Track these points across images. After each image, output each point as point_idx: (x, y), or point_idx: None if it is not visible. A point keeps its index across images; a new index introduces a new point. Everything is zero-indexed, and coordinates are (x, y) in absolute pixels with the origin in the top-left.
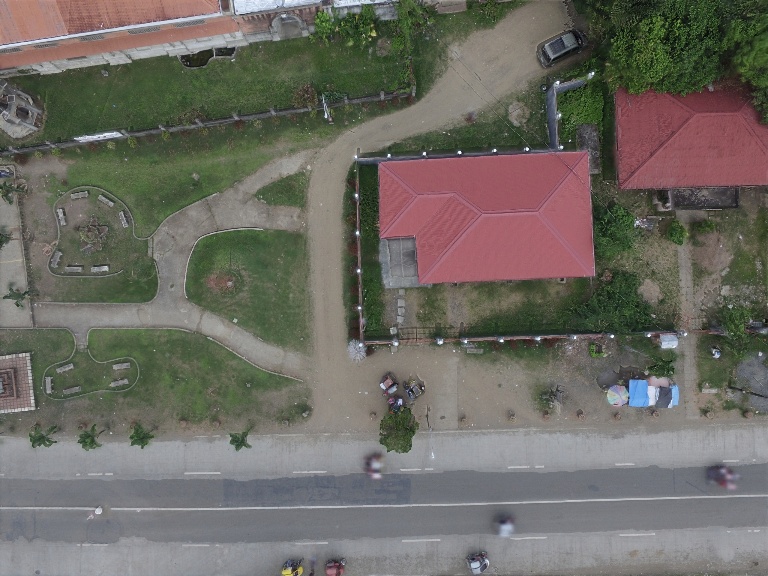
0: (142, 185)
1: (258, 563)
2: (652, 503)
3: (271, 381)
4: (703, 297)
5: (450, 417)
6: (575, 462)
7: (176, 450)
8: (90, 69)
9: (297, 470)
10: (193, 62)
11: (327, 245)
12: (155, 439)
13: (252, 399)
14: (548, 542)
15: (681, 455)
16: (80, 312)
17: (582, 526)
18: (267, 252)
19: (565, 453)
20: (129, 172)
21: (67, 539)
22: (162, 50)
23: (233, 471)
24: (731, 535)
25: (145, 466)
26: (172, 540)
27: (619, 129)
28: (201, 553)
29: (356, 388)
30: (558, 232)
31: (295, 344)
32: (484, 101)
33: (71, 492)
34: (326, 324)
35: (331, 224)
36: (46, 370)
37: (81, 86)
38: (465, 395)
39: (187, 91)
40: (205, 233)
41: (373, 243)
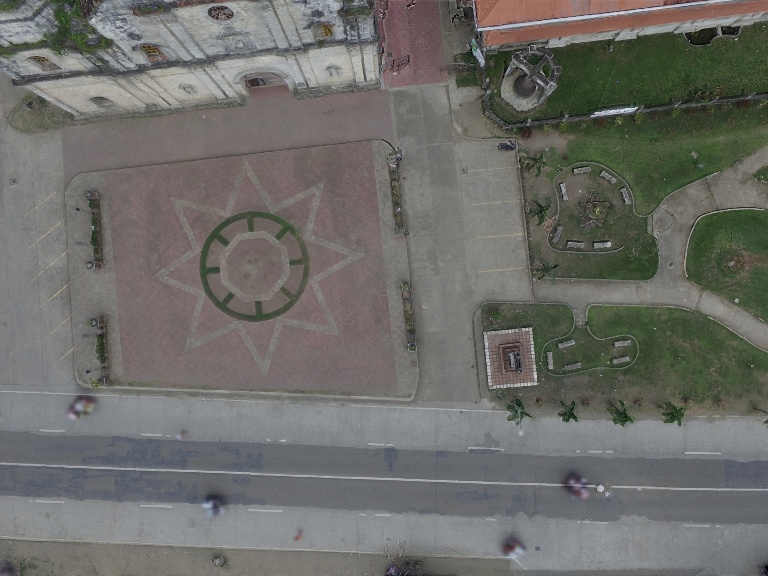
0: (642, 162)
1: (758, 545)
2: None
3: None
4: None
5: None
6: None
7: (676, 429)
8: (594, 44)
9: None
10: (694, 40)
11: None
12: (655, 418)
13: (753, 380)
14: None
15: None
16: (579, 288)
17: None
18: (767, 233)
19: None
20: (629, 148)
21: (567, 516)
22: (675, 26)
23: (733, 452)
24: None
25: (645, 444)
26: (673, 520)
27: None
28: (702, 533)
29: None
30: None
31: None
32: None
33: (571, 469)
34: None
35: None
36: (545, 345)
37: (584, 61)
38: None
39: (691, 69)
40: (705, 212)
41: None
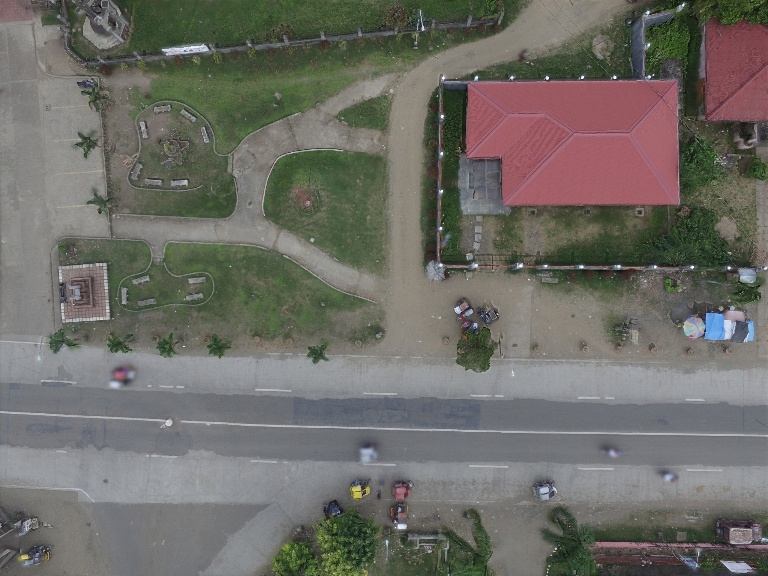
0: (224, 102)
1: (325, 482)
2: (721, 440)
3: (345, 302)
4: None
5: (522, 345)
6: (645, 395)
7: (248, 366)
8: None
9: (367, 391)
10: None
11: (407, 169)
12: (227, 354)
13: (326, 319)
14: (615, 474)
15: (751, 393)
16: (158, 225)
17: (650, 459)
18: (346, 173)
19: (636, 386)
20: (212, 88)
21: (136, 449)
22: None
23: (304, 389)
24: None
25: (216, 380)
26: (240, 455)
27: (704, 64)
28: (269, 469)
29: (430, 312)
30: (647, 156)
31: (371, 266)
32: (568, 33)
33: (142, 403)
34: (402, 247)
35: (411, 148)
36: (122, 281)
37: (168, 1)
38: (538, 324)
39: (273, 10)
40: (285, 152)
41: (453, 169)
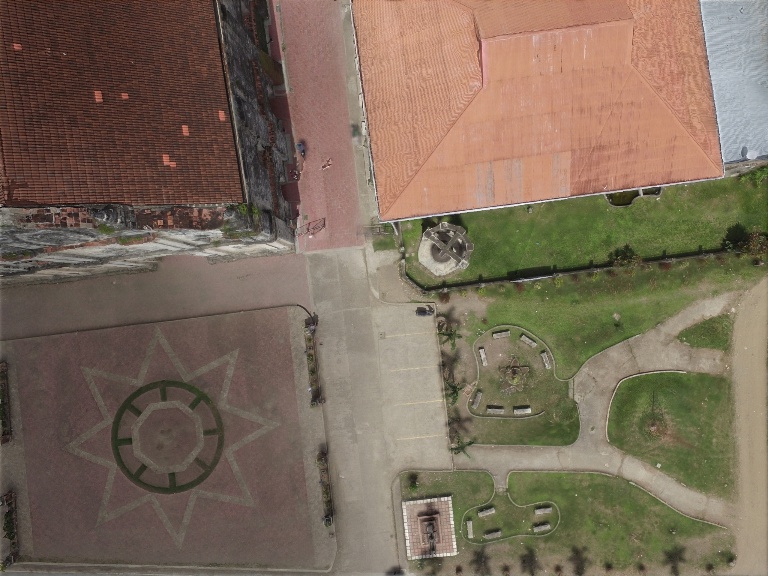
0: (563, 324)
1: None
2: None
3: (694, 528)
4: None
5: None
6: None
7: None
8: None
9: None
10: (615, 199)
11: (752, 390)
12: None
13: (675, 546)
14: None
15: None
16: (499, 454)
17: None
18: (690, 396)
19: None
20: (550, 311)
21: None
22: None
23: None
24: None
25: None
26: None
27: None
28: None
29: None
30: None
31: (718, 490)
32: None
33: None
34: (751, 471)
35: (756, 368)
36: (465, 513)
37: (504, 222)
38: None
39: (612, 230)
40: (627, 375)
41: None
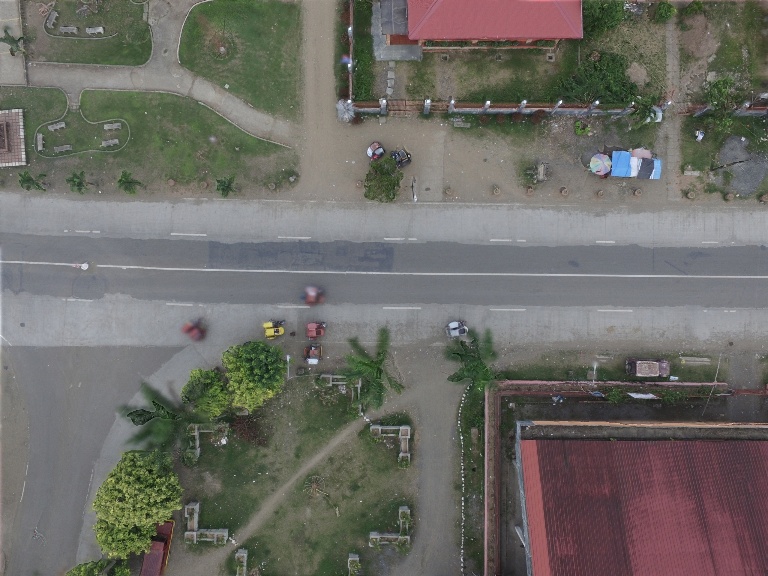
0: None
1: (240, 324)
2: (631, 281)
3: (260, 147)
4: (689, 82)
5: (435, 189)
6: (556, 238)
7: (163, 211)
8: None
9: (282, 235)
10: None
11: (320, 16)
12: (143, 199)
13: (240, 164)
14: (527, 315)
15: (661, 235)
16: (74, 73)
17: (561, 300)
18: (261, 21)
19: (547, 229)
20: None
21: (53, 293)
22: None
23: (219, 233)
24: (707, 315)
25: (132, 225)
26: (156, 298)
27: None
28: (184, 312)
29: (343, 157)
30: None
31: (285, 112)
32: None
33: (58, 248)
34: (316, 93)
35: None
36: (38, 128)
37: None
38: (451, 168)
39: None
40: (200, 0)
41: (366, 15)
